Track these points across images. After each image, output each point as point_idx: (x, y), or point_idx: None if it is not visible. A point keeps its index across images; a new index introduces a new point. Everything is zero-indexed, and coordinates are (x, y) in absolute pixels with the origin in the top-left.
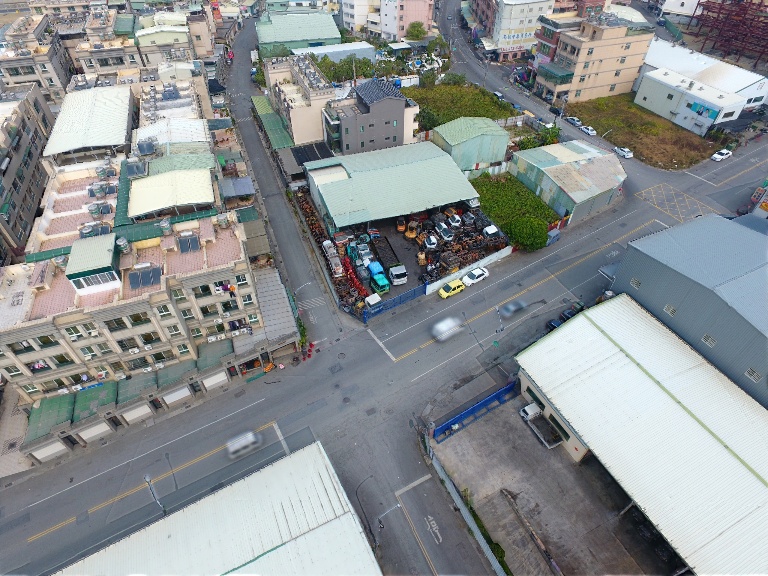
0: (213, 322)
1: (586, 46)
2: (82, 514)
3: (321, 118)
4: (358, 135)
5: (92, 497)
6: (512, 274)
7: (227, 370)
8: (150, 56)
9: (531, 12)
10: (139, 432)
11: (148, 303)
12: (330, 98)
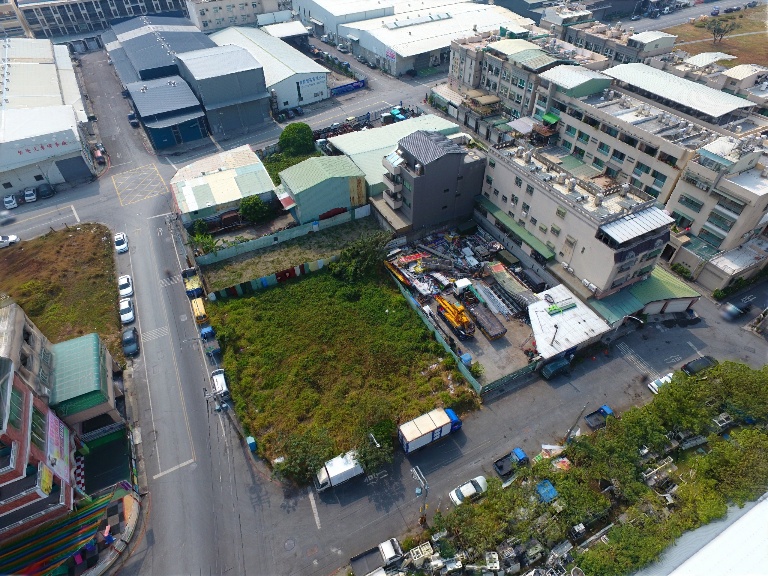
0: None
1: None
2: None
3: None
4: None
5: None
6: None
7: None
8: None
9: None
10: None
11: None
12: None
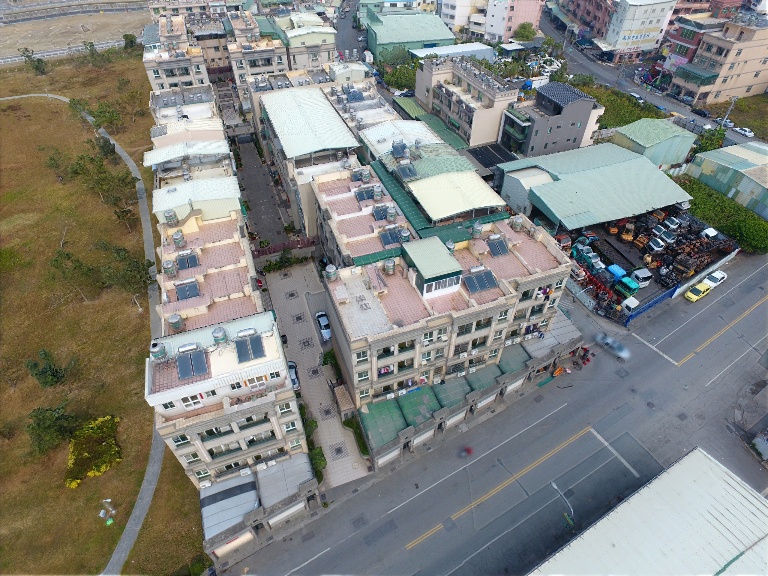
0: (517, 326)
1: (736, 47)
2: (447, 521)
3: (499, 119)
4: (545, 137)
5: (447, 503)
6: (748, 277)
7: (528, 374)
8: (297, 57)
9: (653, 13)
10: (458, 437)
11: (501, 307)
12: (512, 99)
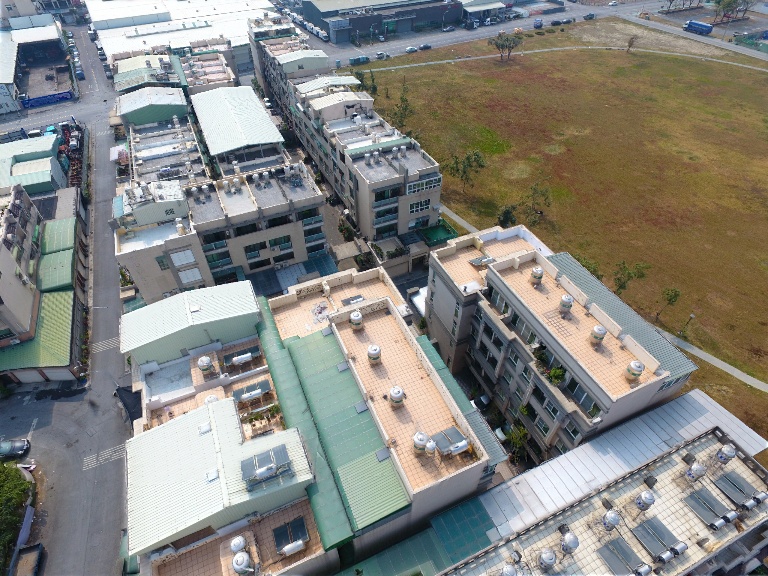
0: None
1: None
2: None
3: None
4: None
5: None
6: None
7: None
8: None
9: None
10: None
11: None
12: None
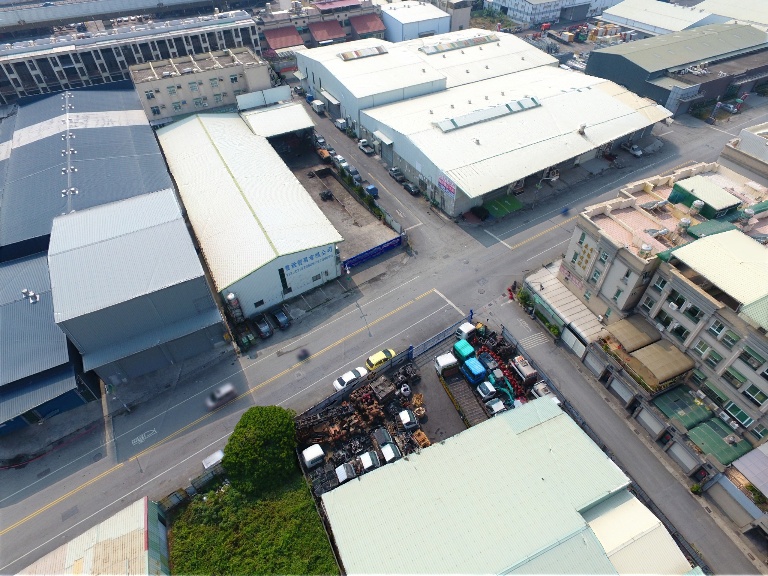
0: None
1: None
2: None
3: None
4: None
5: None
6: (302, 391)
7: None
8: None
9: None
10: None
11: None
12: None
